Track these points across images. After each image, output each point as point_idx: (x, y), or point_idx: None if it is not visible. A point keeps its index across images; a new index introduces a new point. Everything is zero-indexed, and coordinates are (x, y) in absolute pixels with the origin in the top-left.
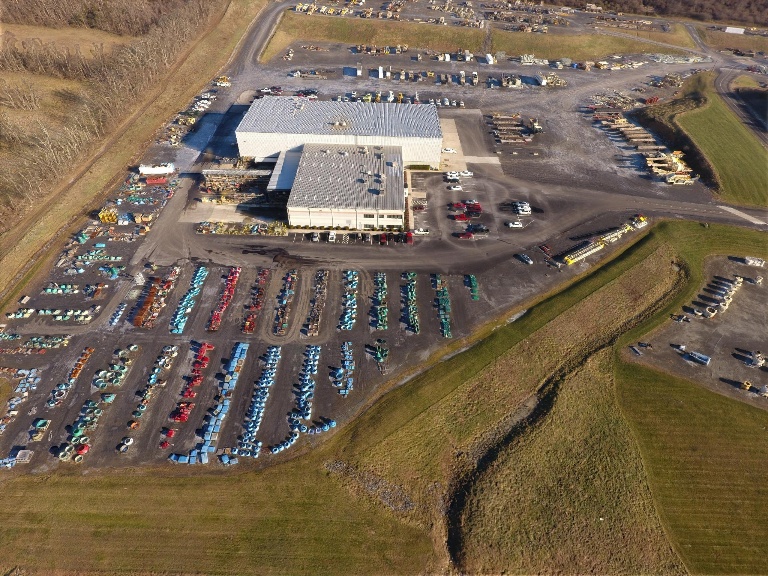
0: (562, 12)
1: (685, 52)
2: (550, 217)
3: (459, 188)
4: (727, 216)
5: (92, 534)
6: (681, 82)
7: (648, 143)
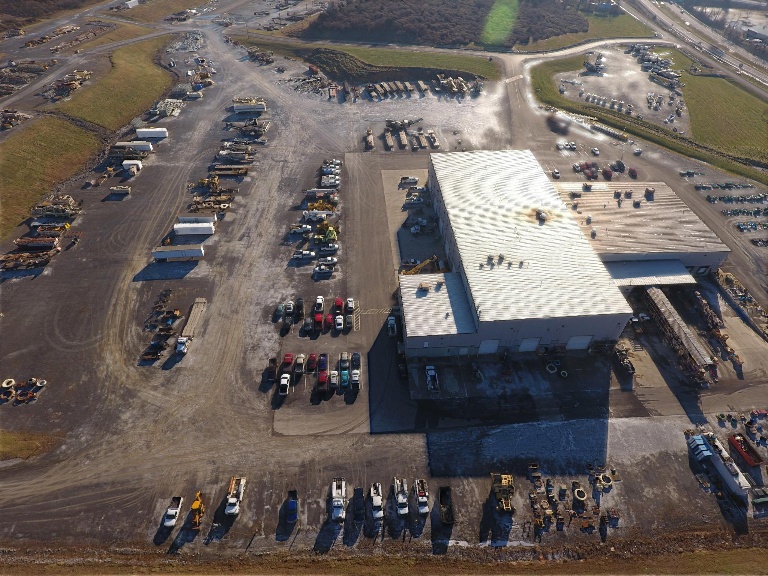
0: None
1: (171, 35)
2: (569, 137)
3: None
4: (520, 82)
5: None
6: None
7: None
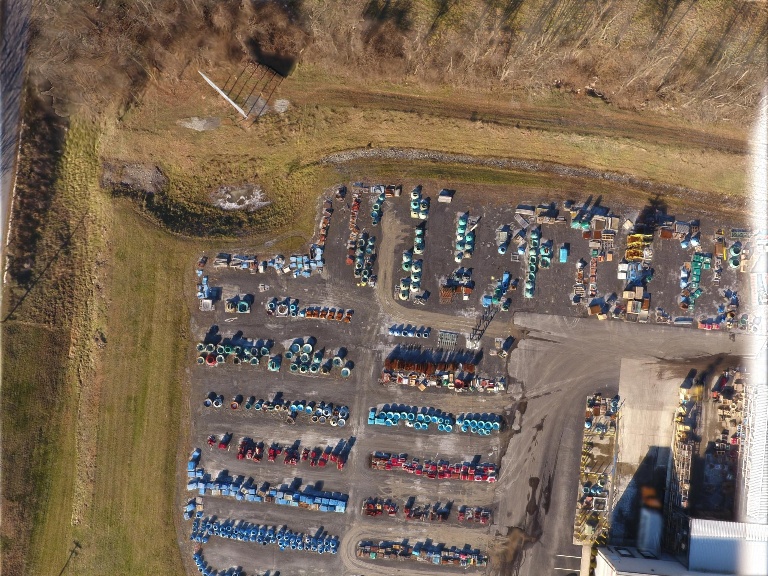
0: None
1: None
2: None
3: None
4: None
5: (129, 396)
6: None
7: None
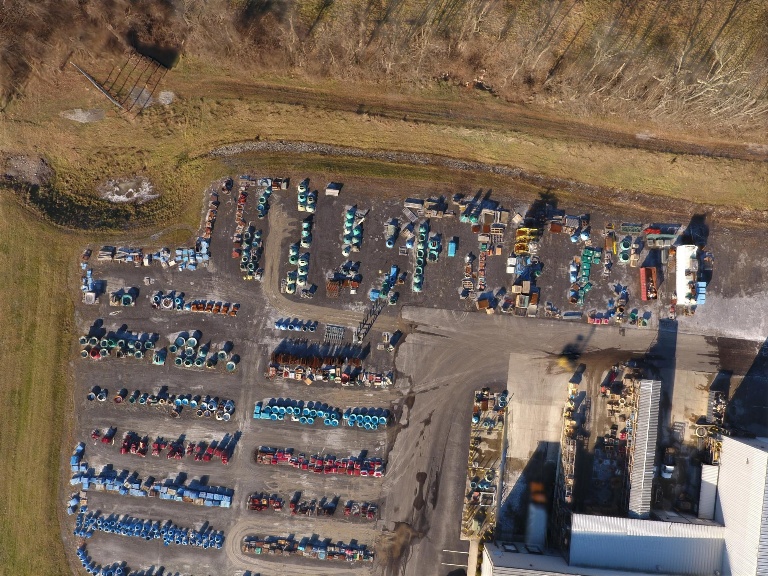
0: None
1: None
2: None
3: None
4: None
5: (13, 390)
6: None
7: None
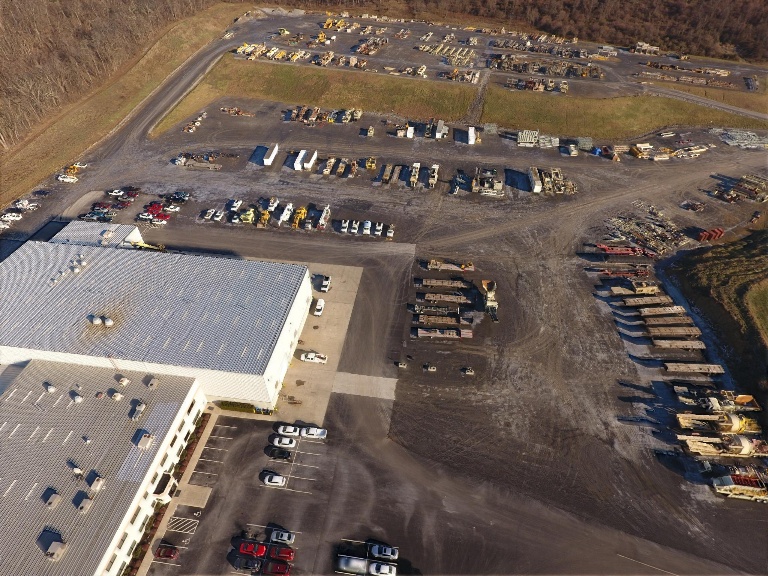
0: (599, 55)
1: None
2: None
3: (278, 483)
4: None
5: None
6: (767, 194)
7: (690, 351)
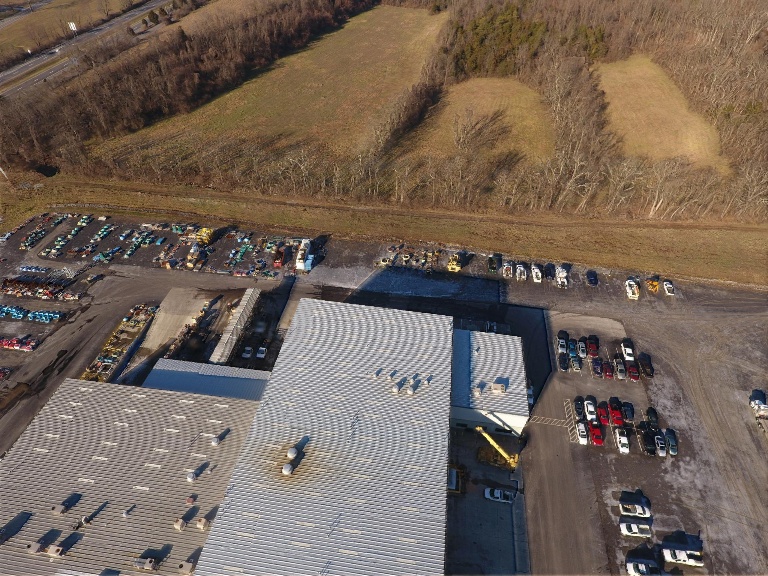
0: None
1: None
2: None
3: None
4: None
5: None
6: None
7: None
